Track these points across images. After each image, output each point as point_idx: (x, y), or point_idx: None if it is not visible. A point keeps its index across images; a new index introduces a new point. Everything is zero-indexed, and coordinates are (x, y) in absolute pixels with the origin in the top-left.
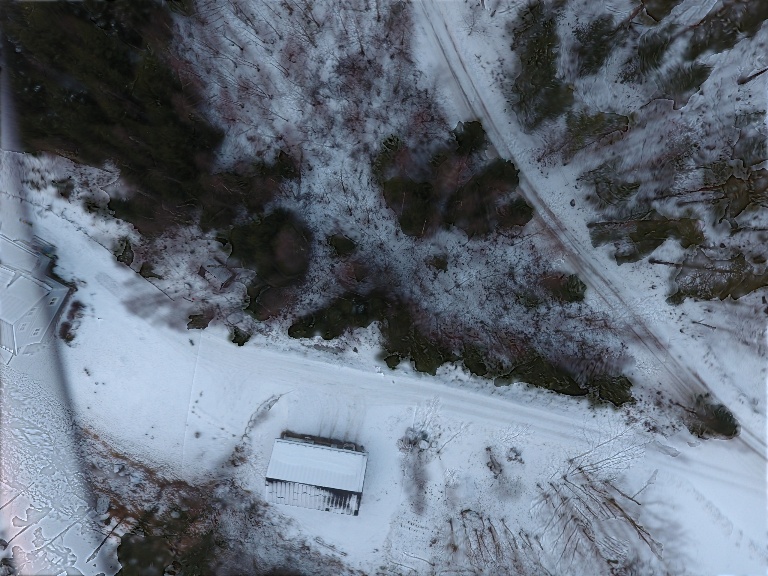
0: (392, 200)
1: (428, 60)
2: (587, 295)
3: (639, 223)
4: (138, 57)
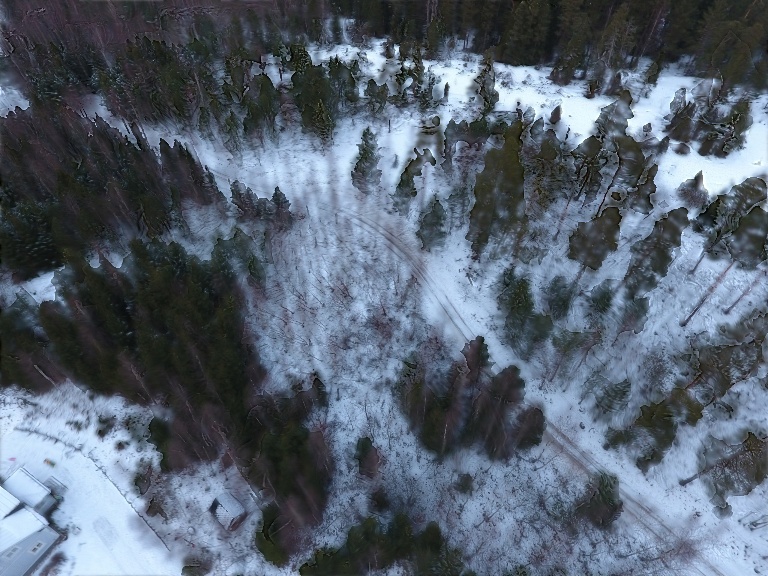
0: (415, 404)
1: (435, 318)
2: (630, 525)
3: (642, 408)
4: (217, 310)
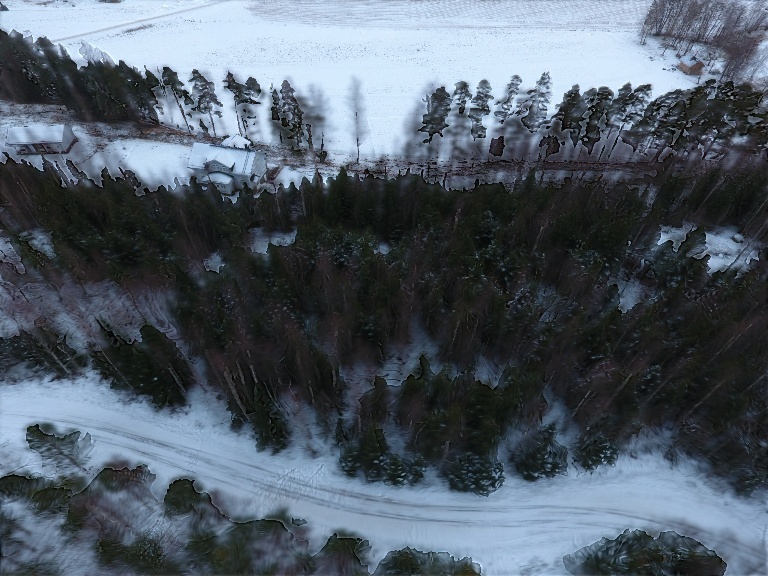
0: None
1: None
2: None
3: None
4: None
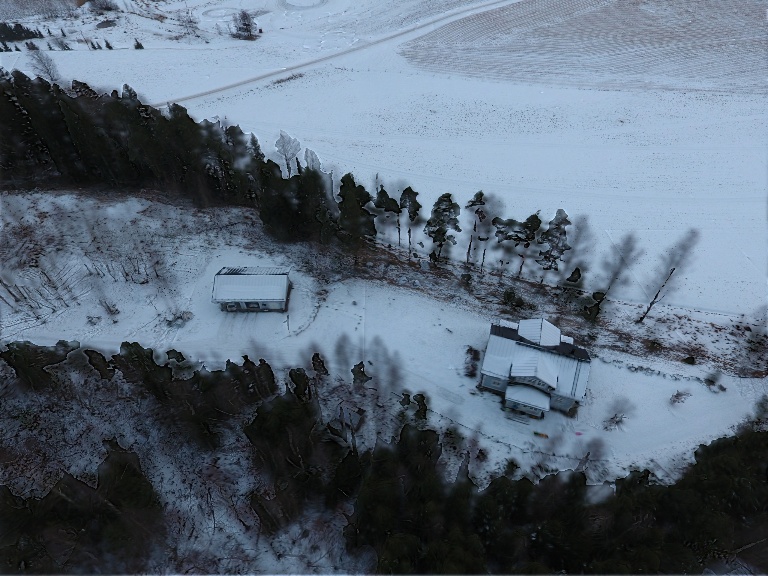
0: None
1: None
2: None
3: None
4: None
